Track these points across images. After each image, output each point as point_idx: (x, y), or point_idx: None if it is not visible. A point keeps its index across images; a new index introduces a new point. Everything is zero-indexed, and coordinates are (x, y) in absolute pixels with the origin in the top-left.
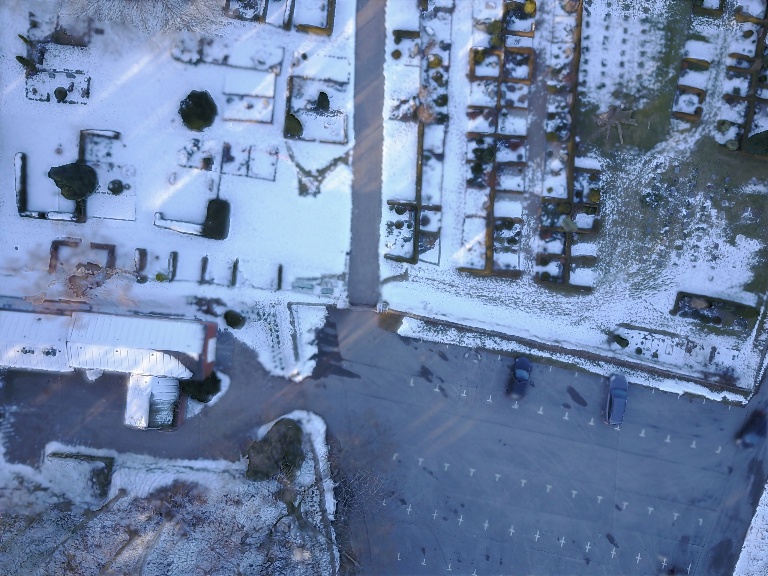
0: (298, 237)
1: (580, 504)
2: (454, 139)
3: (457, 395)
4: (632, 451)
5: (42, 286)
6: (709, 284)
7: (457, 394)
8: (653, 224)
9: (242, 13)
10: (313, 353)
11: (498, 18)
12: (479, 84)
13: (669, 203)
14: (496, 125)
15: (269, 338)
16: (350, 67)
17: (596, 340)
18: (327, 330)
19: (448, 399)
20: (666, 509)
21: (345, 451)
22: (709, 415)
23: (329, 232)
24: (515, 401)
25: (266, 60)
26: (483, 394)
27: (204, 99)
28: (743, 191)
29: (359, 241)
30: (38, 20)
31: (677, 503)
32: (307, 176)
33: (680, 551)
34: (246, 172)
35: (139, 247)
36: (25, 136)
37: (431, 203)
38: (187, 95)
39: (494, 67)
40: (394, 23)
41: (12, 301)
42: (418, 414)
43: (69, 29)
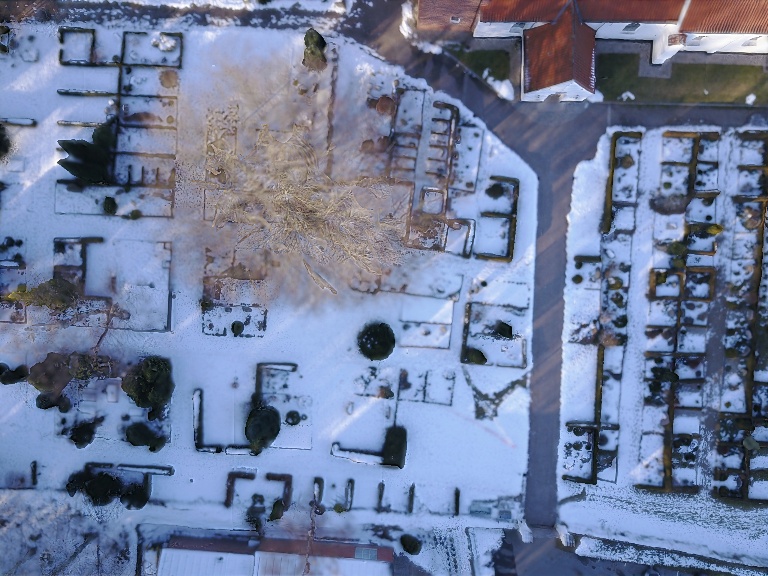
0: (474, 460)
1: None
2: (632, 358)
3: None
4: None
5: (218, 519)
6: None
7: None
8: None
9: (421, 243)
10: (490, 575)
11: (679, 238)
12: (658, 303)
13: None
14: (675, 344)
15: (445, 561)
16: (530, 292)
17: None
18: (504, 551)
19: None
20: None
21: None
22: None
23: (506, 454)
24: None
25: (445, 288)
26: None
27: (386, 333)
28: None
29: (536, 463)
30: (215, 255)
31: None
32: (484, 399)
33: None
34: (423, 398)
35: (315, 476)
36: (201, 371)
37: (609, 422)
38: (363, 323)
39: (674, 287)
40: (575, 248)
41: (183, 528)
42: None
43: (247, 265)
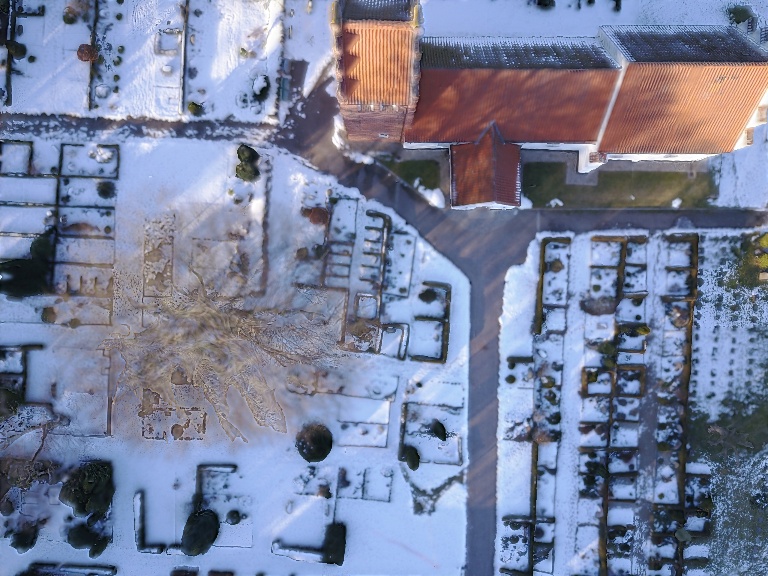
0: (413, 554)
1: None
2: (566, 452)
3: None
4: None
5: None
6: None
7: None
8: (763, 524)
9: (357, 346)
10: None
11: (610, 338)
12: (591, 400)
13: None
14: (608, 439)
15: None
16: (464, 392)
17: None
18: None
19: None
20: None
21: None
22: None
23: (444, 549)
24: None
25: (381, 390)
26: None
27: (322, 436)
28: None
29: (474, 556)
30: None
31: None
32: (422, 495)
33: None
34: (361, 495)
35: (256, 573)
36: (142, 473)
37: (545, 516)
38: (302, 424)
39: (606, 384)
40: (508, 349)
41: None
42: None
43: None
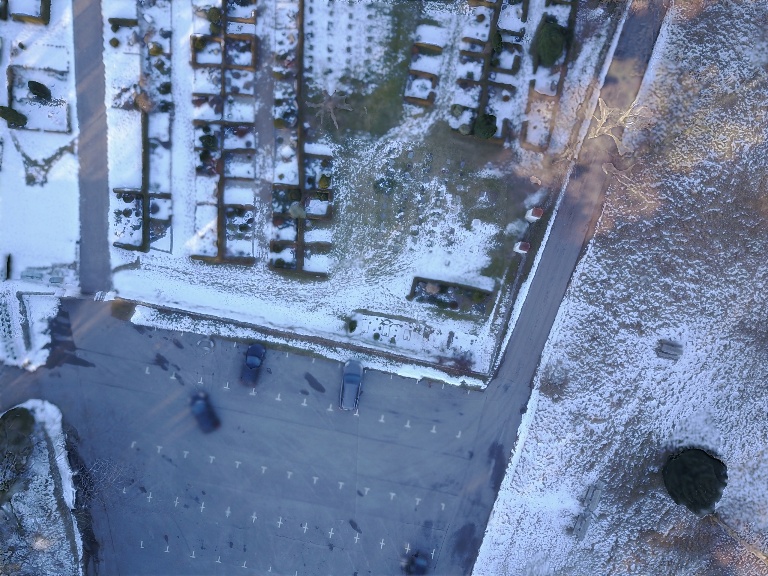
0: (27, 226)
1: (321, 490)
2: (181, 127)
3: (194, 383)
4: (372, 437)
5: None
6: (446, 269)
7: (194, 382)
8: (388, 210)
9: None
10: (45, 342)
11: (218, 5)
12: (203, 71)
13: (403, 188)
14: (222, 112)
15: (1, 328)
16: (69, 56)
17: (333, 326)
18: (60, 319)
19: (185, 387)
20: (408, 494)
21: (82, 440)
22: (448, 400)
23: (58, 221)
24: (252, 388)
25: None
26: (220, 381)
27: None
28: (478, 175)
29: (88, 230)
30: None
31: (418, 488)
32: (33, 165)
33: (423, 536)
34: None
35: None
36: None
37: (160, 191)
38: None
39: (216, 54)
40: (110, 11)
41: None
42: (155, 402)
43: None
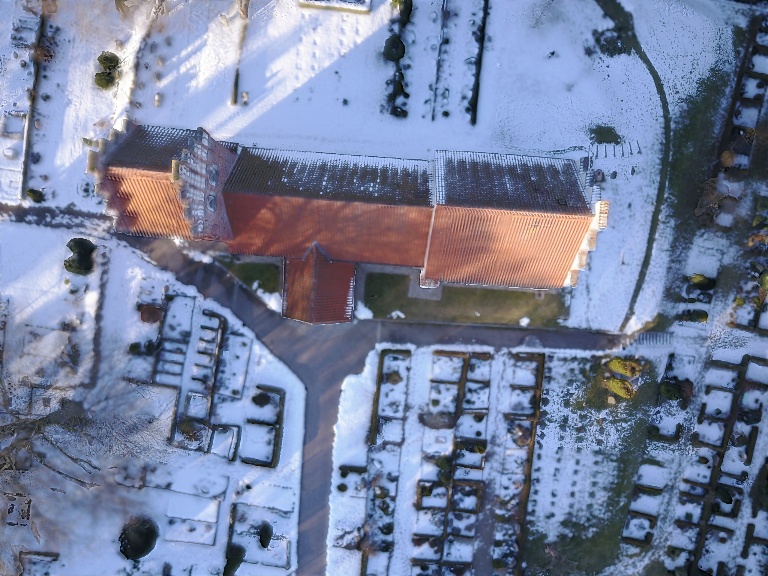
0: None
1: None
2: (399, 562)
3: None
4: None
5: None
6: None
7: None
8: None
9: (187, 444)
10: None
11: (448, 452)
12: (426, 512)
13: None
14: (442, 552)
15: None
16: (295, 497)
17: None
18: None
19: None
20: None
21: None
22: None
23: None
24: None
25: (210, 489)
26: None
27: (144, 533)
28: None
29: None
30: None
31: None
32: None
33: None
34: None
35: None
36: None
37: None
38: (129, 516)
39: (442, 498)
40: (341, 458)
41: None
42: None
43: None
